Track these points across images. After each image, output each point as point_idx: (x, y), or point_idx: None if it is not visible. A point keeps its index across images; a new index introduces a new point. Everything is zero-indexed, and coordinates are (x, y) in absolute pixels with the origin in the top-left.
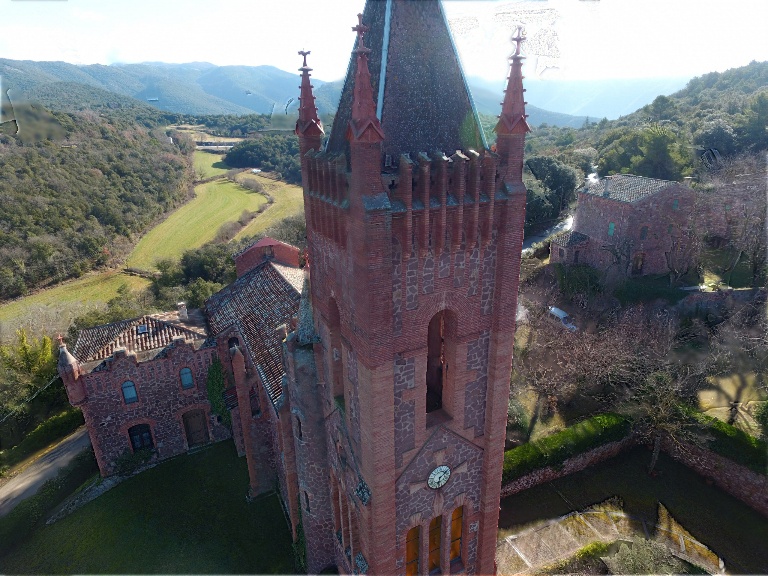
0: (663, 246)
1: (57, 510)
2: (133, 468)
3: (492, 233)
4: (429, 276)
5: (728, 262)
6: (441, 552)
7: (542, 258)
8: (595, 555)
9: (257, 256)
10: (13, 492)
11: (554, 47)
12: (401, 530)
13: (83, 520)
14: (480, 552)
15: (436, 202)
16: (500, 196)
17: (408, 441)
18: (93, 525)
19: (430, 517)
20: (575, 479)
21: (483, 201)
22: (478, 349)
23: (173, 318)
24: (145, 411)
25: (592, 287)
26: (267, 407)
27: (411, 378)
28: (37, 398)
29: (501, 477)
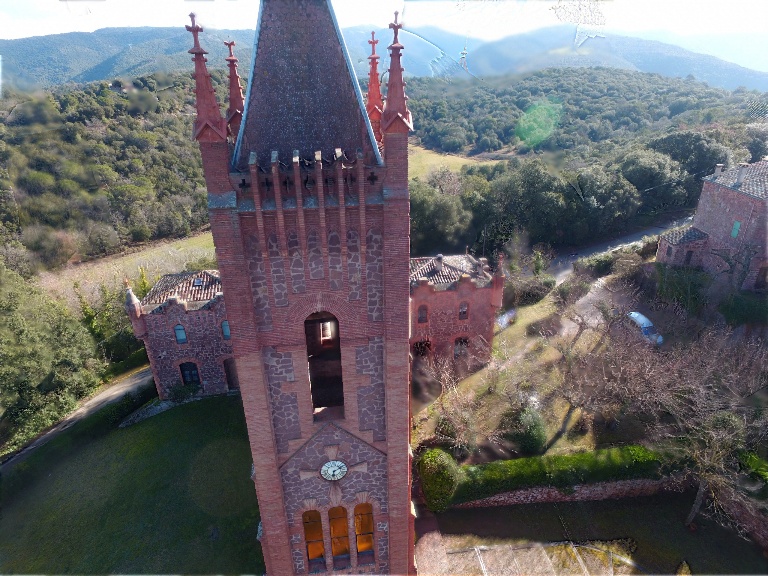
0: None
1: (128, 418)
2: (183, 397)
3: (375, 238)
4: (299, 276)
5: None
6: None
7: (653, 254)
8: None
9: None
10: (110, 396)
11: (598, 12)
12: (295, 510)
13: (141, 430)
14: (389, 552)
15: (293, 203)
16: (375, 200)
17: (294, 430)
18: (144, 436)
19: (327, 505)
20: (588, 508)
21: (350, 205)
22: (370, 355)
23: None
24: (193, 352)
25: (693, 296)
26: None
27: (290, 372)
28: None
29: (407, 486)
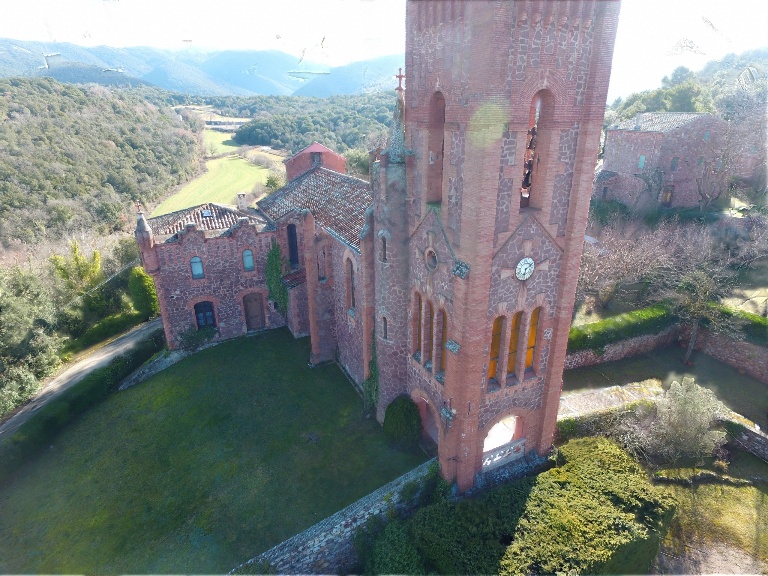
0: (692, 178)
1: (128, 379)
2: (197, 344)
3: None
4: (536, 49)
5: (760, 183)
6: (517, 355)
7: None
8: (642, 408)
9: (307, 162)
10: (81, 372)
11: None
12: (489, 316)
13: (155, 384)
14: (552, 360)
15: None
16: None
17: (503, 222)
18: (165, 386)
19: (514, 310)
20: (614, 365)
21: None
22: (568, 141)
23: (233, 209)
24: (210, 289)
25: (622, 216)
26: (332, 274)
27: (512, 155)
28: (88, 308)
29: None
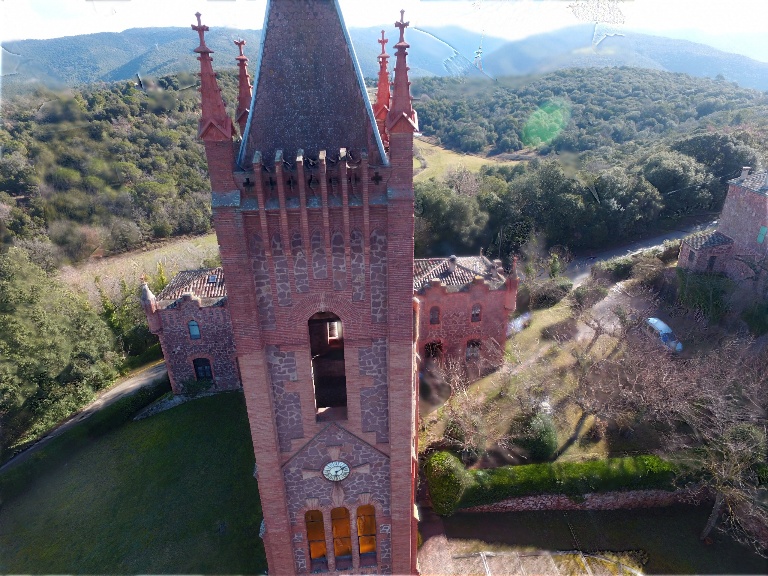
0: None
1: (142, 411)
2: (196, 392)
3: (379, 239)
4: (303, 275)
5: None
6: None
7: (675, 259)
8: None
9: None
10: (126, 389)
11: (617, 10)
12: (298, 509)
13: (154, 424)
14: (392, 555)
15: (296, 203)
16: (379, 200)
17: (297, 429)
18: (157, 430)
19: (330, 506)
20: (599, 517)
21: (354, 205)
22: (373, 356)
23: None
24: (206, 348)
25: (715, 303)
26: None
27: (293, 371)
28: None
29: (410, 489)
